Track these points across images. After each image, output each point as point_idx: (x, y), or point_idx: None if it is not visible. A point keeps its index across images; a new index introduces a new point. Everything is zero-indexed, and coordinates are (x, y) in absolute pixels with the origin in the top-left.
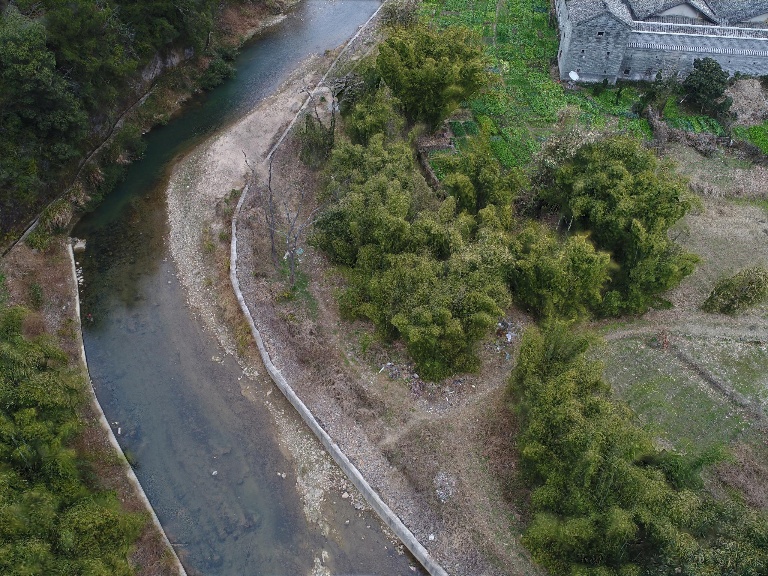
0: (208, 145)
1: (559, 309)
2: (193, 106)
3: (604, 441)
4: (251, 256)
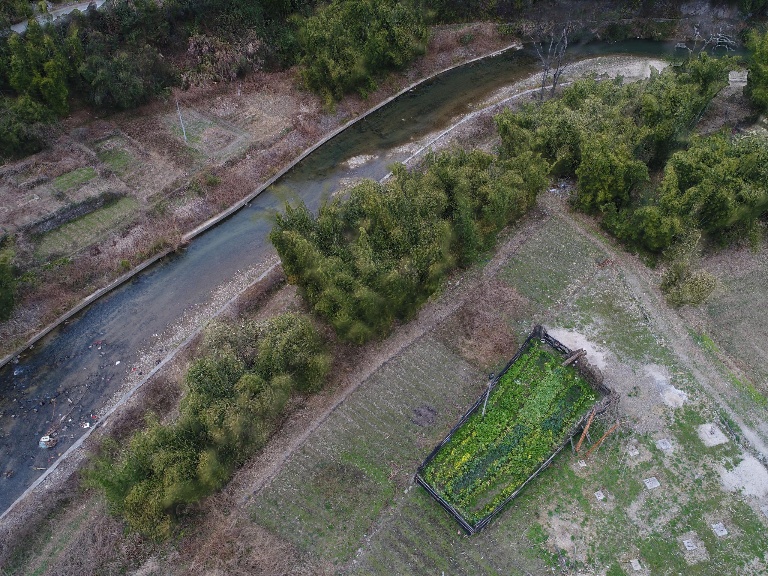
0: (651, 59)
1: (577, 183)
2: (692, 45)
3: (445, 159)
4: (545, 86)
